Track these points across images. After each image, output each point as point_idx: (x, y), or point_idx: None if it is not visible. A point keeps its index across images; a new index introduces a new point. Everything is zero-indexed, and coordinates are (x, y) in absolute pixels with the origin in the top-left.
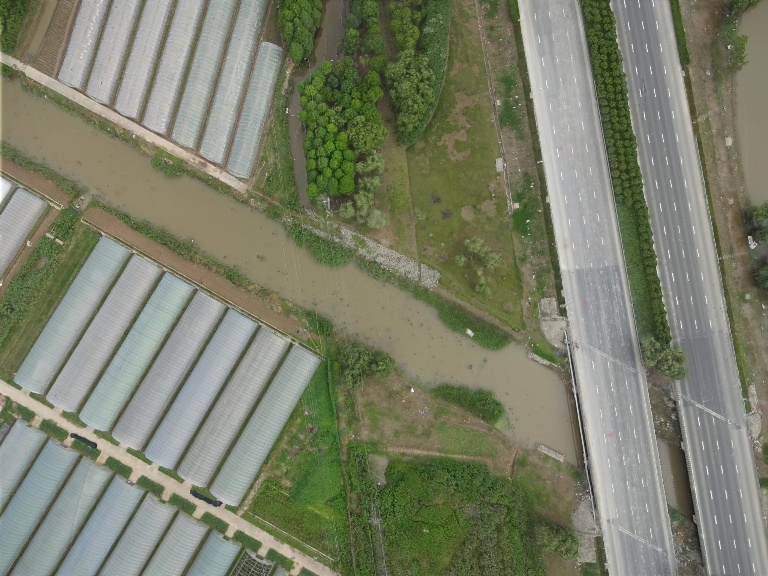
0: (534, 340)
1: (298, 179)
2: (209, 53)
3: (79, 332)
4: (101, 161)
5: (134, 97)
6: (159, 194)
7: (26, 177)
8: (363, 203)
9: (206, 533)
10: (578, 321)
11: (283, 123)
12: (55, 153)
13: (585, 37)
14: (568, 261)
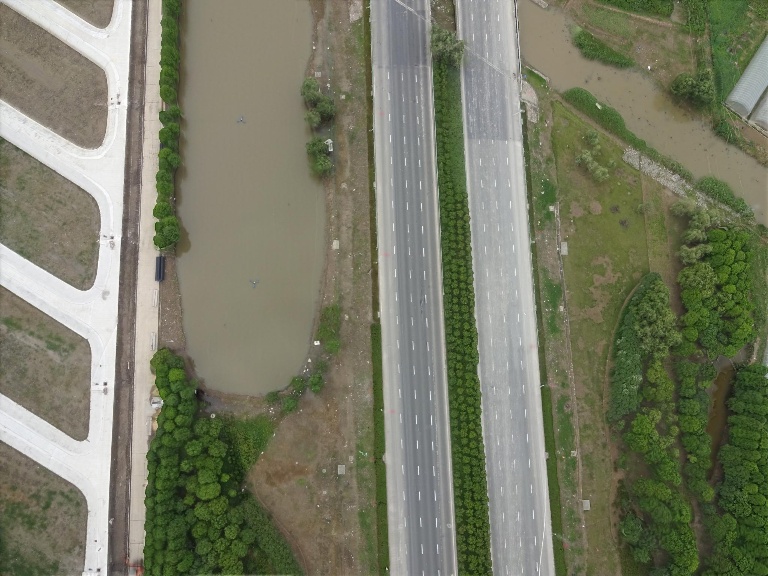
0: (544, 91)
1: None
2: None
3: None
4: None
5: None
6: None
7: None
8: (706, 215)
9: None
10: (511, 96)
11: (759, 309)
12: None
13: None
14: (514, 149)
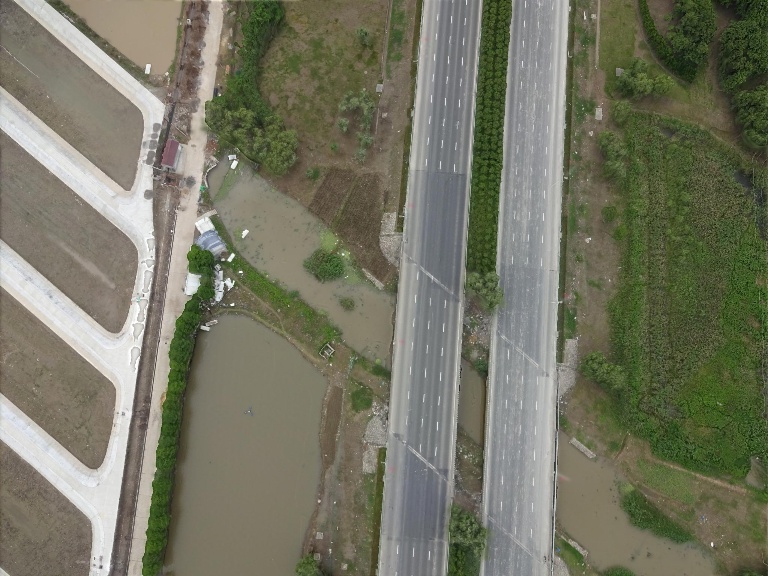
0: (580, 570)
1: None
2: None
3: None
4: None
5: None
6: None
7: None
8: None
9: None
10: None
11: None
12: None
13: None
14: None
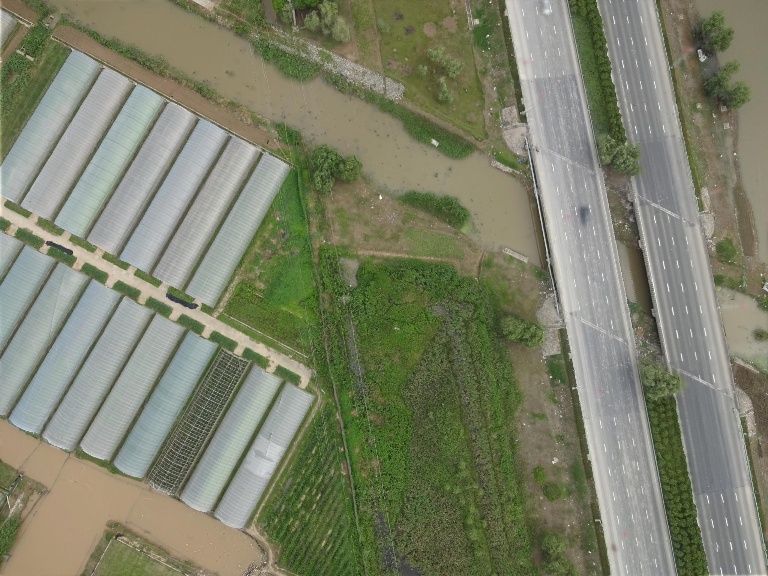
0: (496, 149)
1: None
2: None
3: (52, 143)
4: None
5: None
6: (128, 13)
7: None
8: (327, 10)
9: (183, 334)
10: (538, 127)
11: None
12: None
13: None
14: (527, 71)
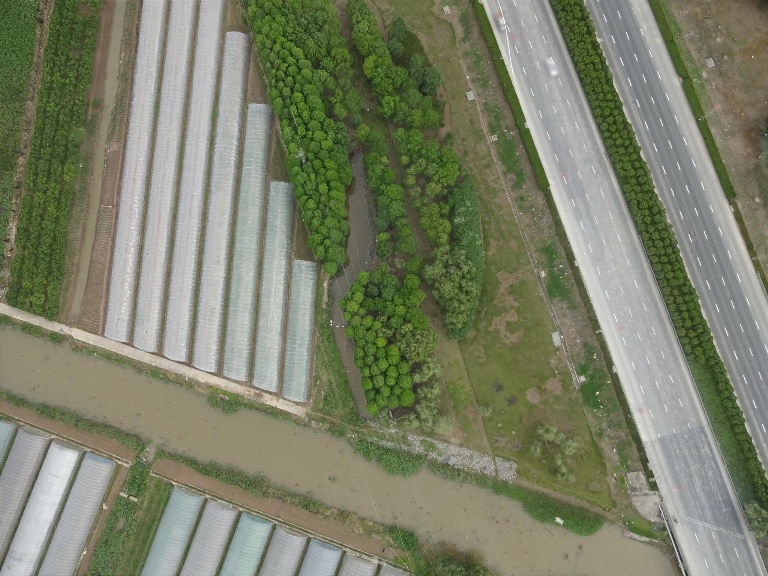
0: (628, 517)
1: (355, 391)
2: (245, 281)
3: None
4: (159, 409)
5: (180, 340)
6: (221, 432)
7: (91, 440)
8: (427, 416)
9: None
10: (671, 493)
11: (330, 338)
12: (114, 409)
13: (621, 191)
14: (648, 431)
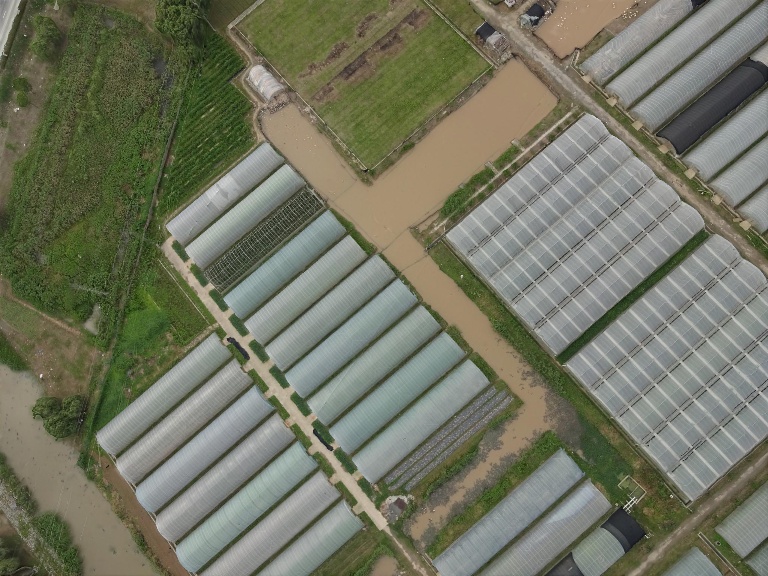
0: None
1: None
2: None
3: None
4: None
5: None
6: None
7: None
8: None
9: None
10: None
11: None
12: None
13: None
14: None
